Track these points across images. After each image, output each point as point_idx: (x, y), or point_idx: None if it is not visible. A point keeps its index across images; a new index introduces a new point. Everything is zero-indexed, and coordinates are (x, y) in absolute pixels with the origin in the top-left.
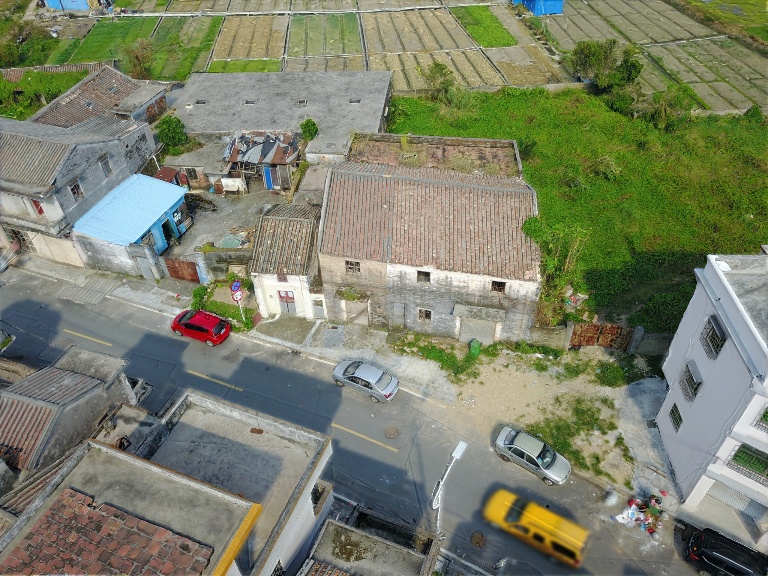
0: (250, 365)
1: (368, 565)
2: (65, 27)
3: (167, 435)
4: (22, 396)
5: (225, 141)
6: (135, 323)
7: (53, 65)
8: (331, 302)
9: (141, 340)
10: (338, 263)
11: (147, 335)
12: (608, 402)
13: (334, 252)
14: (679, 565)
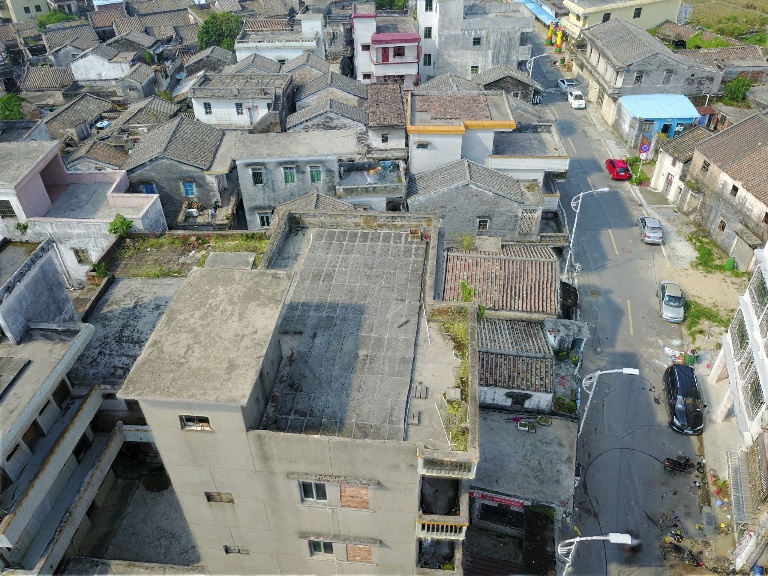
0: (614, 194)
1: (528, 193)
2: None
3: (531, 132)
4: (512, 99)
5: (765, 111)
6: (596, 153)
7: (736, 40)
8: (684, 191)
9: (589, 159)
10: (700, 160)
11: (594, 159)
12: None
13: (702, 150)
14: (660, 377)
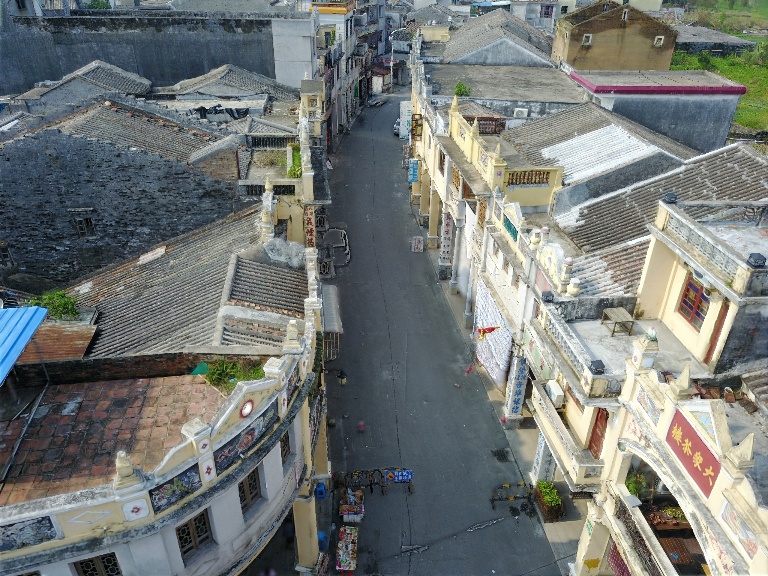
0: None
1: None
2: (759, 33)
3: None
4: None
5: None
6: None
7: None
8: None
9: None
10: None
11: None
12: None
13: None
14: None
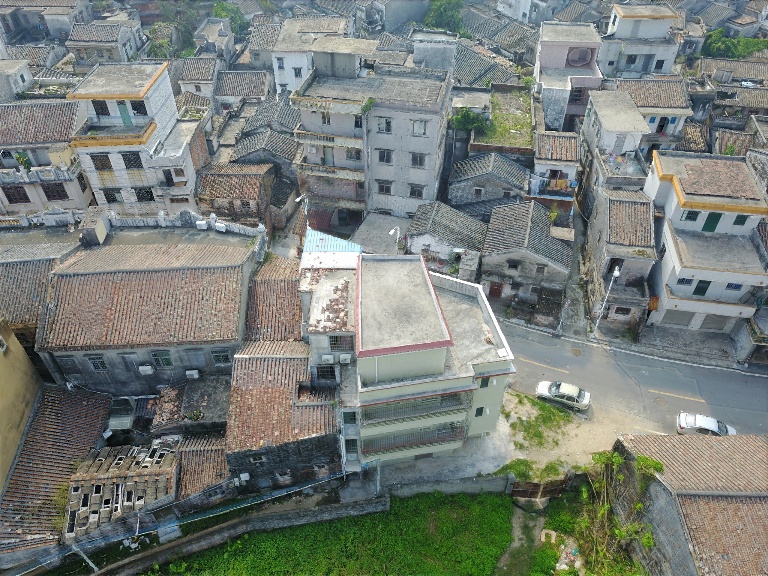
0: None
1: (629, 250)
2: None
3: None
4: None
5: None
6: None
7: None
8: None
9: None
10: None
11: None
12: (519, 446)
13: None
14: None
